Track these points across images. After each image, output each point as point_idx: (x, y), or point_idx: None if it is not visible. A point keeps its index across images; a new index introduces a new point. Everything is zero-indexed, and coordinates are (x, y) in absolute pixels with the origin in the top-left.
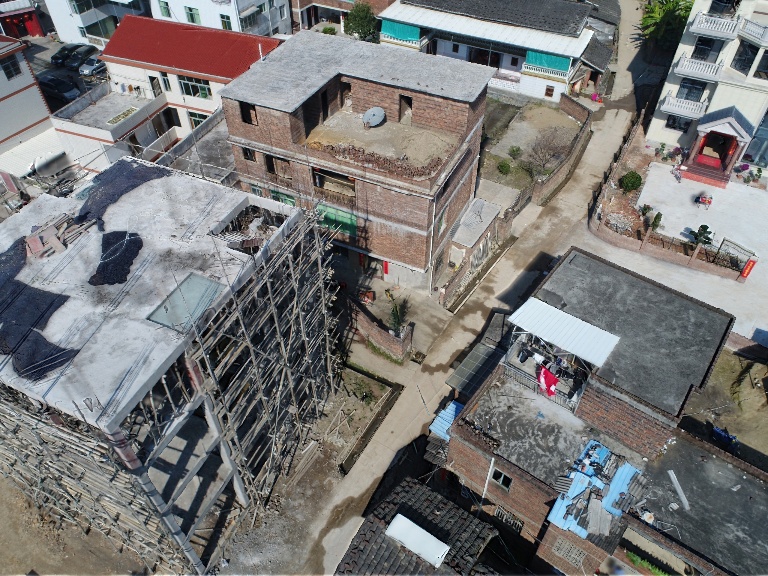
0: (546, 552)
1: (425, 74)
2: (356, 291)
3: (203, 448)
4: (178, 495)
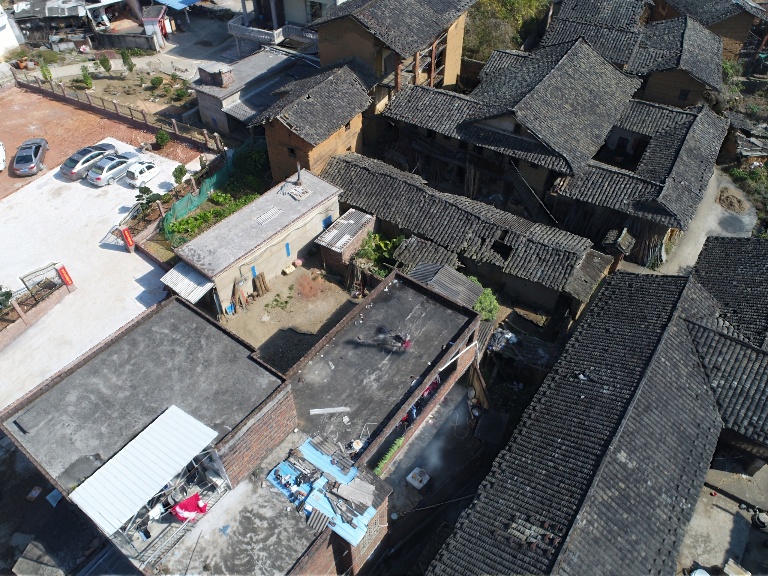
0: (359, 563)
1: None
2: None
3: None
4: None
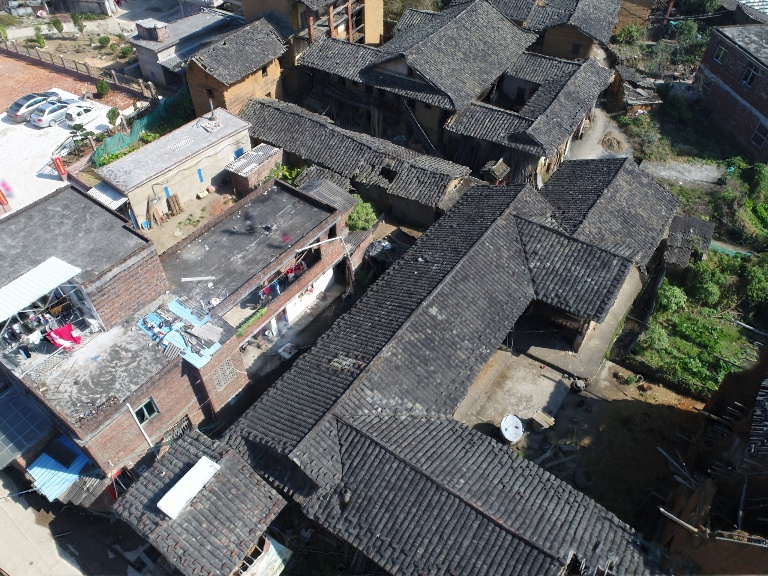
0: (218, 400)
1: None
2: None
3: None
4: None
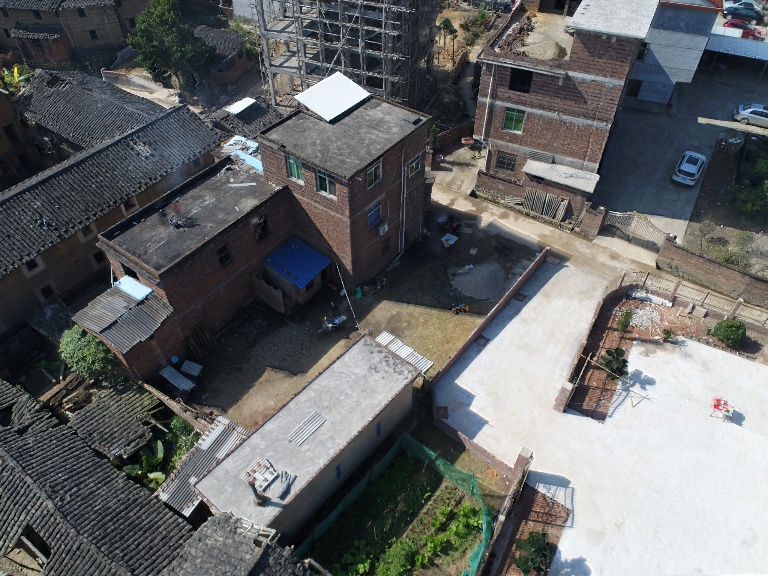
0: None
1: (609, 8)
2: (480, 142)
3: (292, 35)
4: (271, 36)
